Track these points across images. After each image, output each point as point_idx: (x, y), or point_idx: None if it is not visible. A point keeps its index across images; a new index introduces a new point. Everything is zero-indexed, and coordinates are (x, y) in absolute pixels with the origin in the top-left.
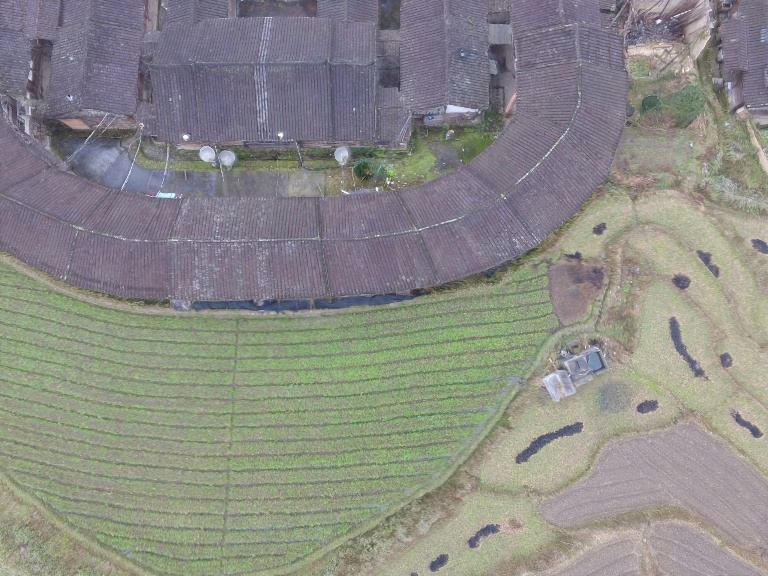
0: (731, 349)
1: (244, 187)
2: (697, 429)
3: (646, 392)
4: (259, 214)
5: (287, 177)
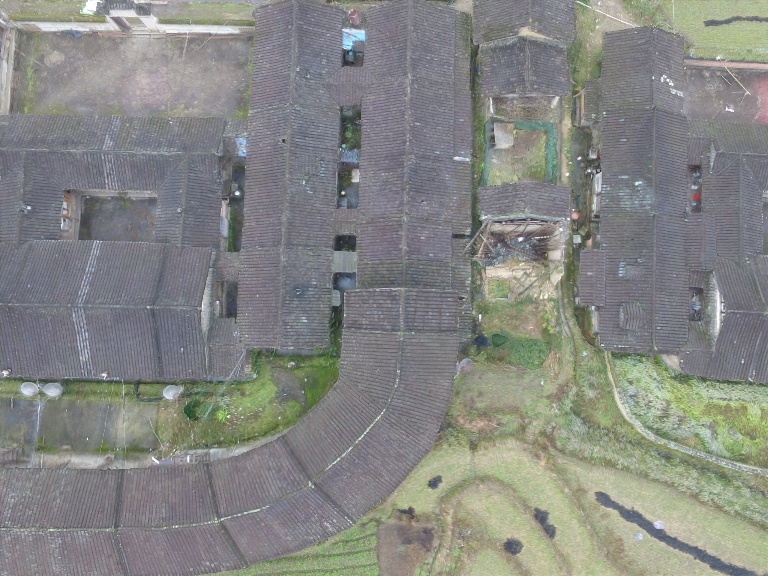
0: None
1: (72, 420)
2: None
3: None
4: (57, 493)
5: (117, 409)
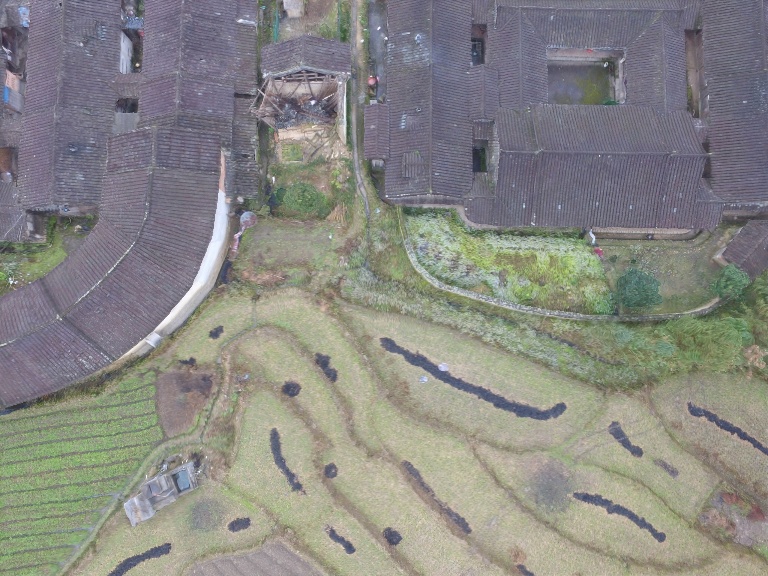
0: (337, 459)
1: None
2: (285, 548)
3: (238, 509)
4: None
5: None
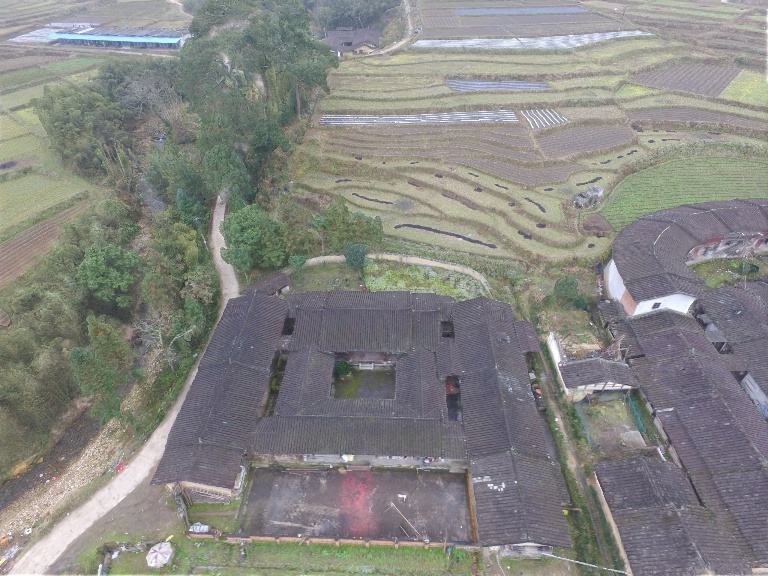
0: None
1: None
2: None
3: None
4: None
5: None
